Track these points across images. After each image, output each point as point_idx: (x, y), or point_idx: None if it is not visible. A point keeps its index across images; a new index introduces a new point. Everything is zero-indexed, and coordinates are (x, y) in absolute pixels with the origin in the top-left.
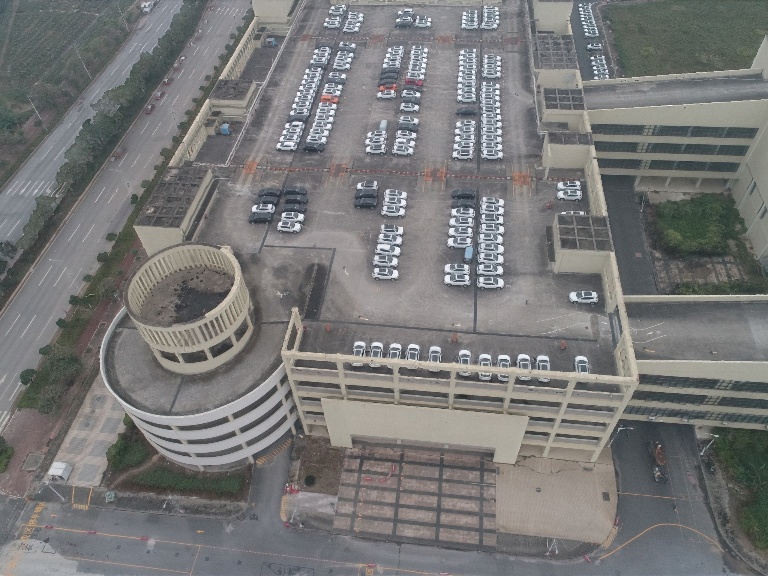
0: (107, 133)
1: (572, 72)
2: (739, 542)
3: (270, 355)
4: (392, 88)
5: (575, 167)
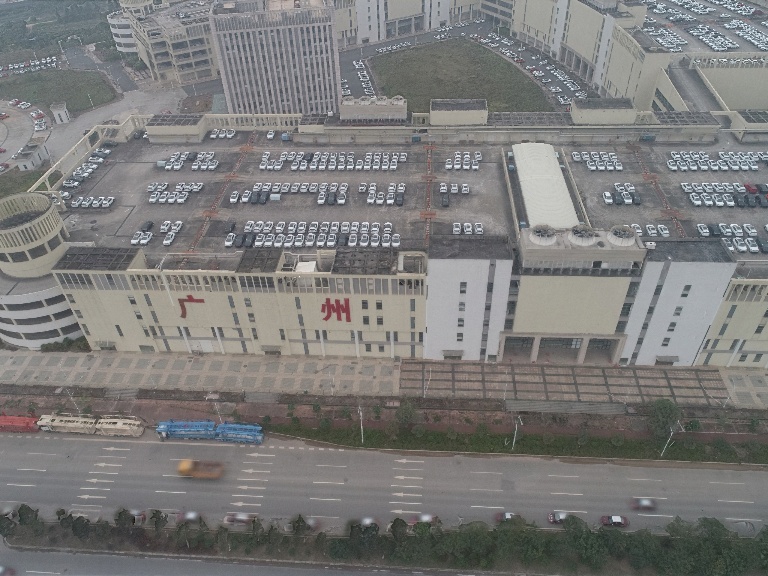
0: None
1: None
2: None
3: None
4: None
5: None
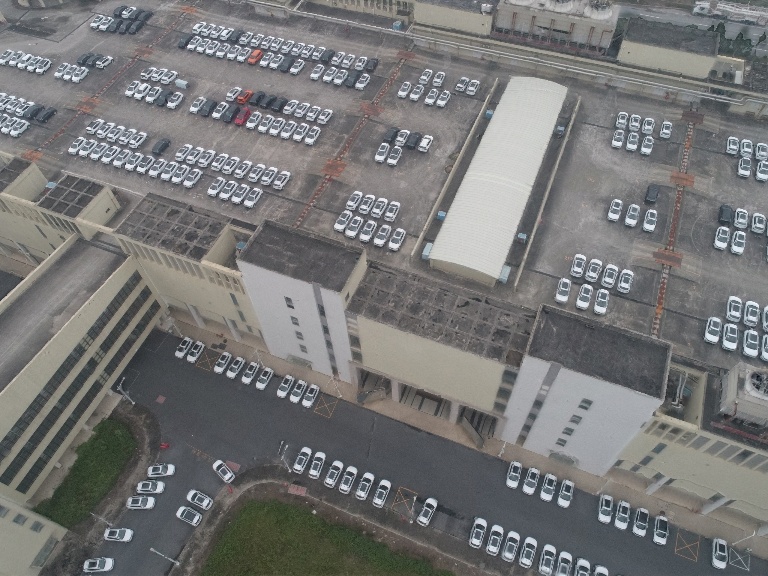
0: None
1: None
2: None
3: (4, 13)
4: None
5: None
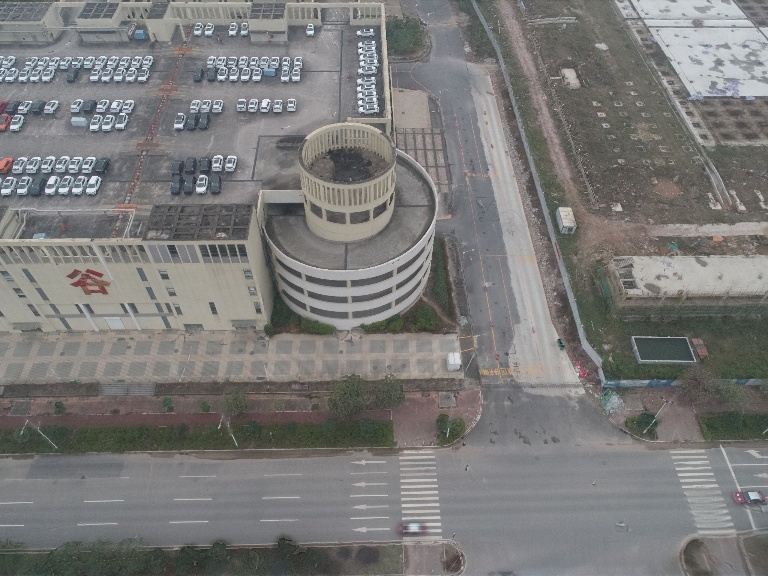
0: None
1: (54, 7)
2: (415, 57)
3: None
4: (8, 117)
5: (174, 28)
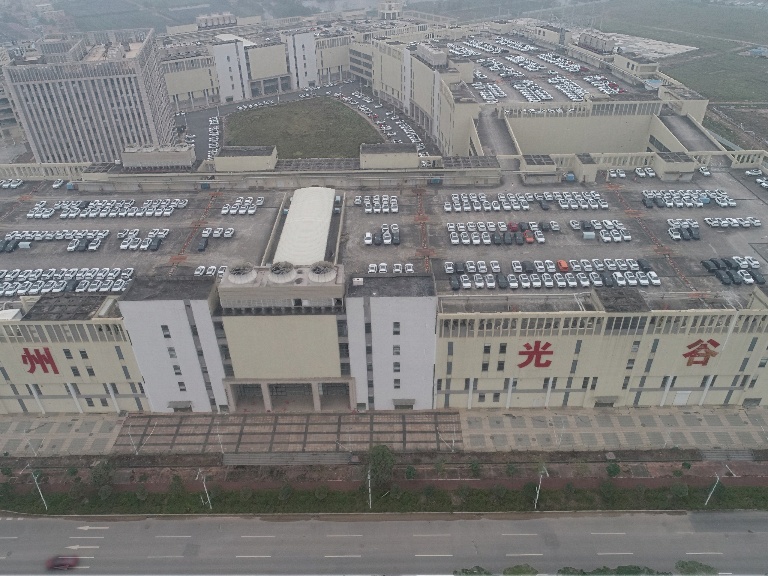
0: (623, 569)
1: None
2: None
3: None
4: None
5: None
